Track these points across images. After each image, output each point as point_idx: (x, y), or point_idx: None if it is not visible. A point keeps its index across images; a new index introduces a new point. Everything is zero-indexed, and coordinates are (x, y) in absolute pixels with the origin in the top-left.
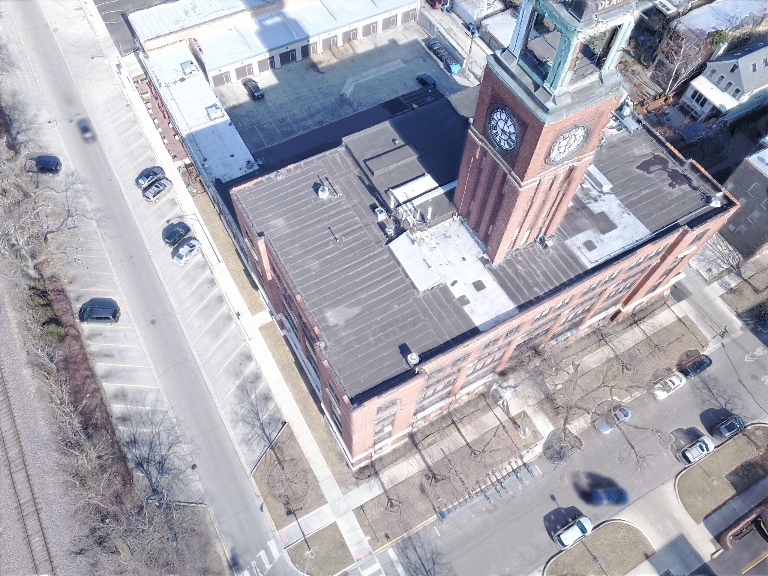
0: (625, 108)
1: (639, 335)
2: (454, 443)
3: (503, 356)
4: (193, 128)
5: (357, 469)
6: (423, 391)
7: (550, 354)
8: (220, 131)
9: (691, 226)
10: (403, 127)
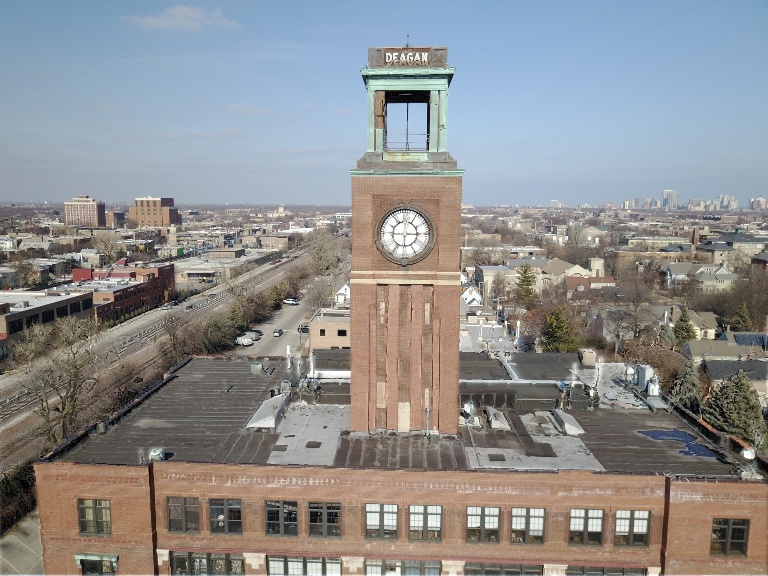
0: (649, 385)
1: None
2: None
3: None
4: None
5: None
6: (151, 529)
7: None
8: None
9: None
10: None
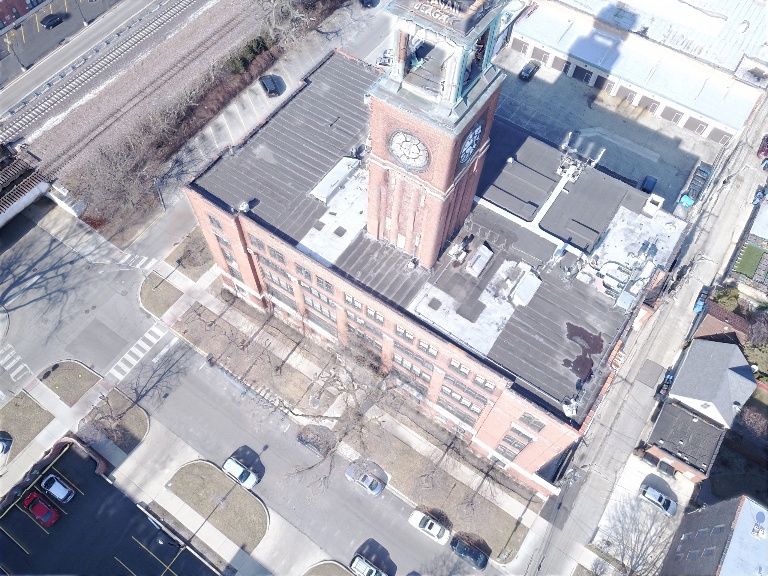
0: (635, 283)
1: (473, 482)
2: (280, 351)
3: (337, 322)
4: None
5: (226, 288)
6: (241, 242)
7: (403, 400)
8: None
9: (519, 391)
10: None
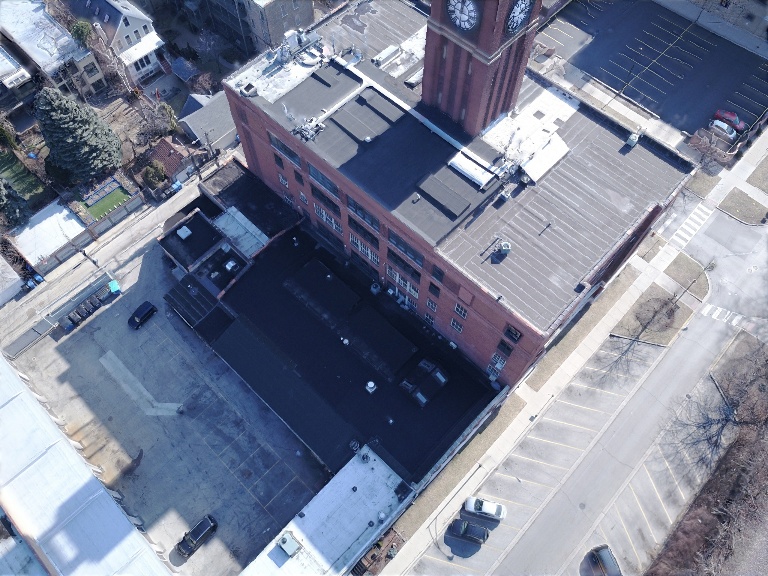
0: None
1: None
2: None
3: None
4: (323, 567)
5: None
6: None
7: None
8: (317, 525)
9: None
10: (392, 198)
